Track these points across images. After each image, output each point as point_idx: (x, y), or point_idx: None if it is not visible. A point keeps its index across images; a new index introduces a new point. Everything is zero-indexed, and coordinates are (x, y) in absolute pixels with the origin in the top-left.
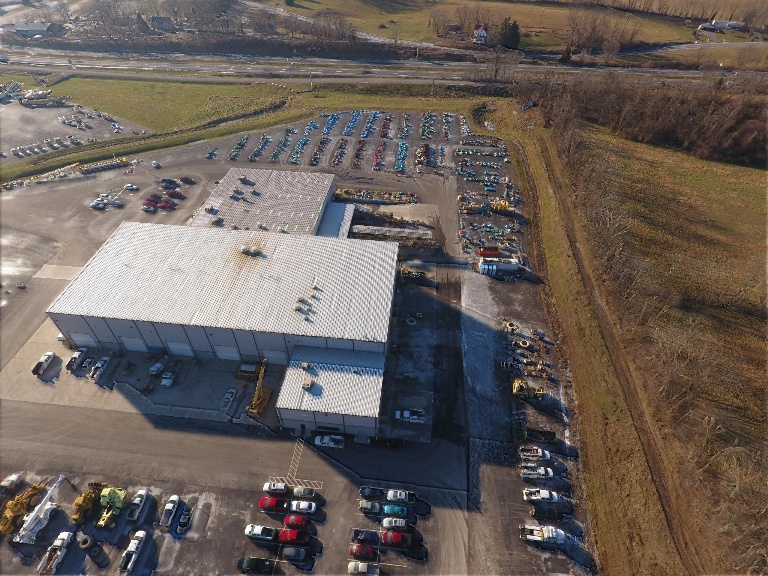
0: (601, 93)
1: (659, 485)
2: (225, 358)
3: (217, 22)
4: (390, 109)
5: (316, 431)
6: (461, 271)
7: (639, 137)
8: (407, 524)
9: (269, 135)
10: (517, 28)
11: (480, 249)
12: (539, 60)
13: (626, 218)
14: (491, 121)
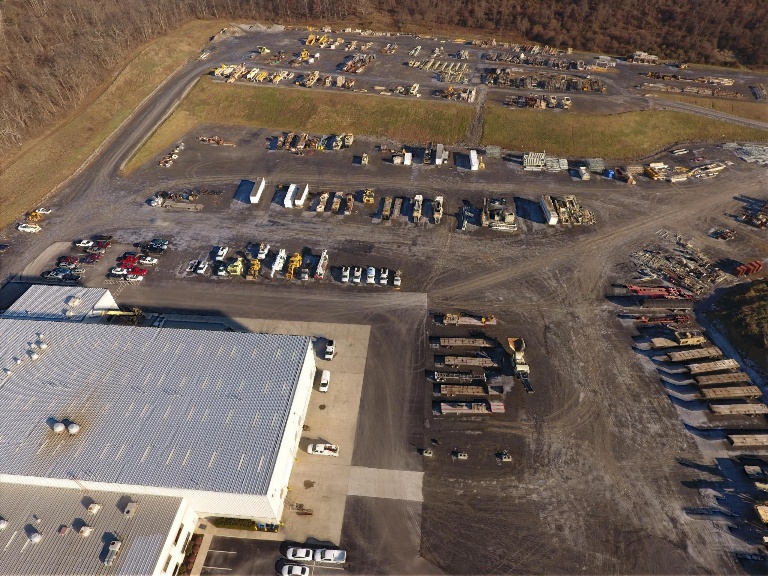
0: None
1: None
2: None
3: None
4: None
5: None
6: None
7: None
8: None
9: None
10: None
11: None
12: None
13: None
14: None
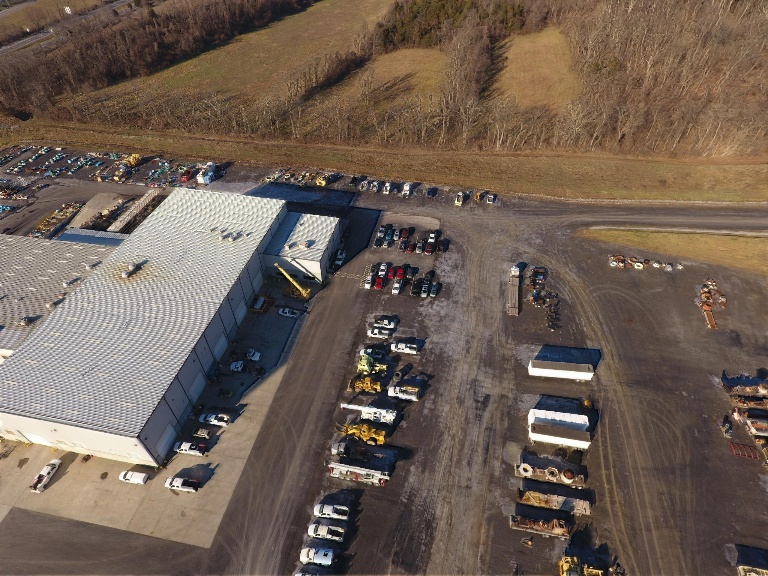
0: (26, 71)
1: None
2: (240, 321)
3: None
4: None
5: (330, 266)
6: None
7: (99, 85)
8: None
9: None
10: None
11: (183, 177)
12: None
13: None
14: None
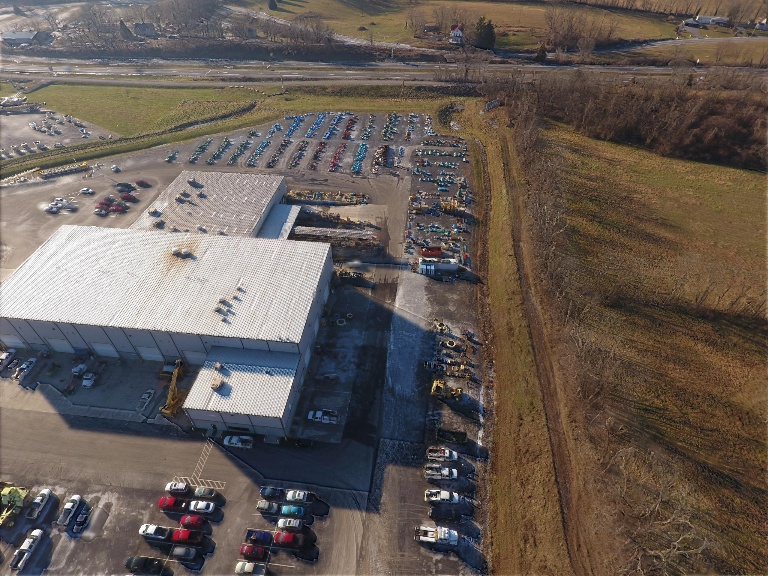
0: (565, 91)
1: (562, 486)
2: (150, 359)
3: (201, 27)
4: (357, 110)
5: (227, 431)
6: (400, 271)
7: (601, 135)
8: (302, 524)
9: (232, 138)
10: (492, 27)
11: (422, 249)
12: (514, 59)
13: (575, 217)
14: (457, 121)
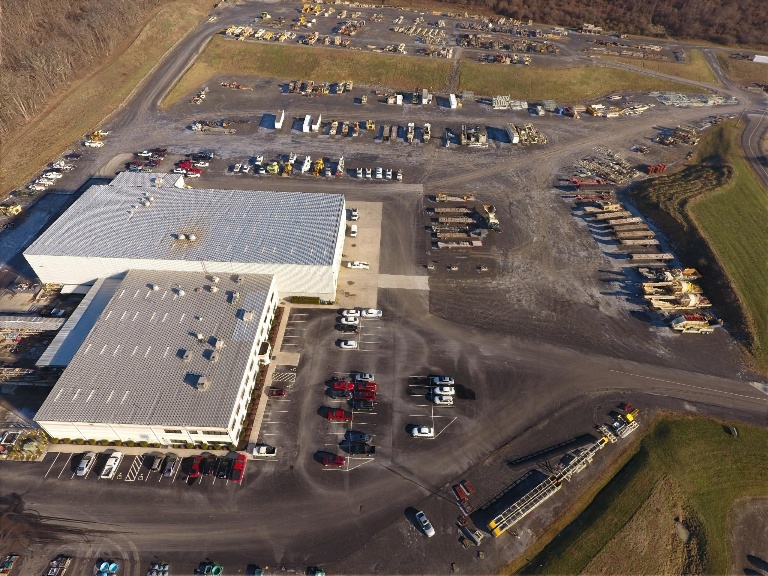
0: None
1: None
2: None
3: None
4: None
5: None
6: None
7: None
8: None
9: None
10: None
11: None
12: None
13: None
14: None
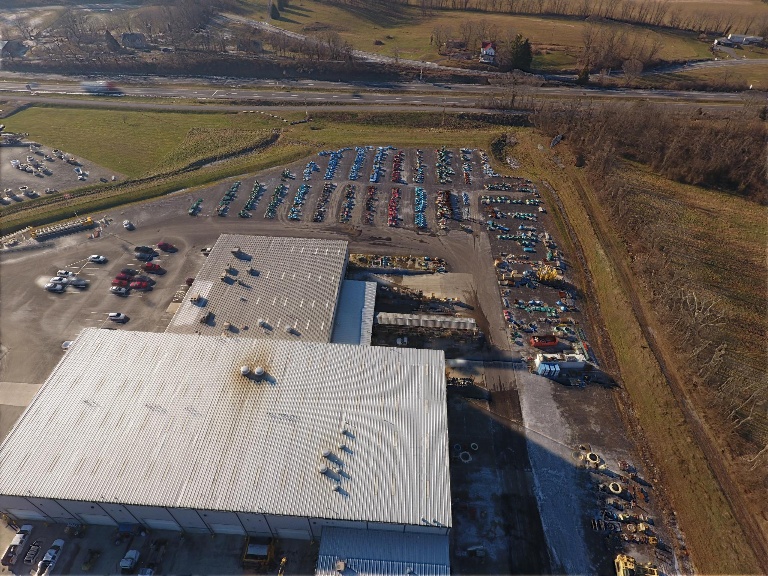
0: (639, 126)
1: None
2: (224, 532)
3: (196, 38)
4: (399, 144)
5: None
6: (515, 372)
7: (687, 178)
8: None
9: (263, 181)
10: (529, 46)
11: (534, 339)
12: (554, 82)
13: (698, 289)
14: (513, 157)
